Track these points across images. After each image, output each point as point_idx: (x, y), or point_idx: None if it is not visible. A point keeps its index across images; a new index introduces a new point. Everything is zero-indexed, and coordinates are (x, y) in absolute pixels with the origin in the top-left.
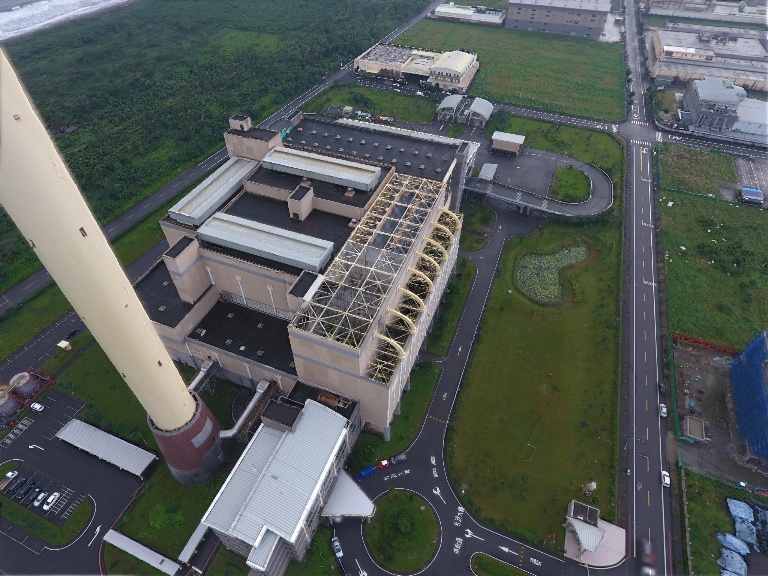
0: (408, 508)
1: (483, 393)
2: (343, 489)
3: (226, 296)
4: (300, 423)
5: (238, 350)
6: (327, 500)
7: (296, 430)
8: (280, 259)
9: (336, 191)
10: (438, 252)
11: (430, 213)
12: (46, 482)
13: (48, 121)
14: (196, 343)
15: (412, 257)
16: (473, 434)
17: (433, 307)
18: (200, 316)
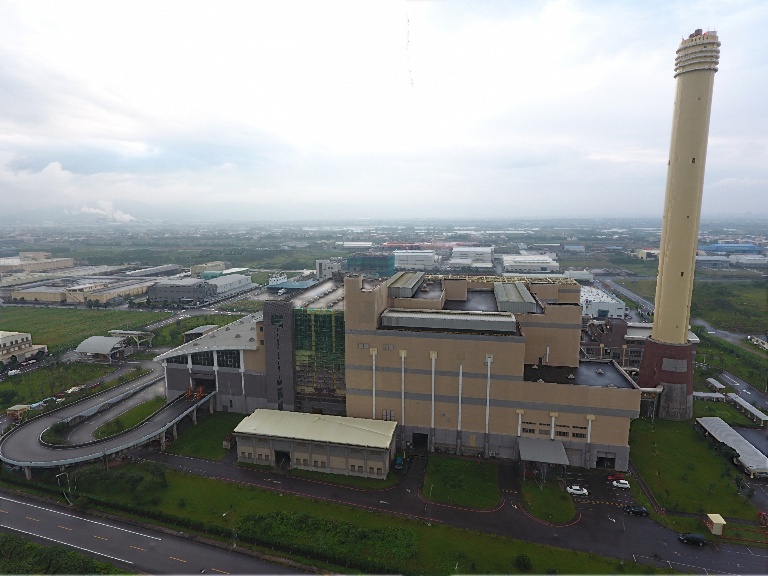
0: None
1: None
2: None
3: None
4: None
5: None
6: None
7: None
8: None
9: (427, 286)
10: None
11: None
12: None
13: None
14: None
15: None
16: None
17: None
18: None
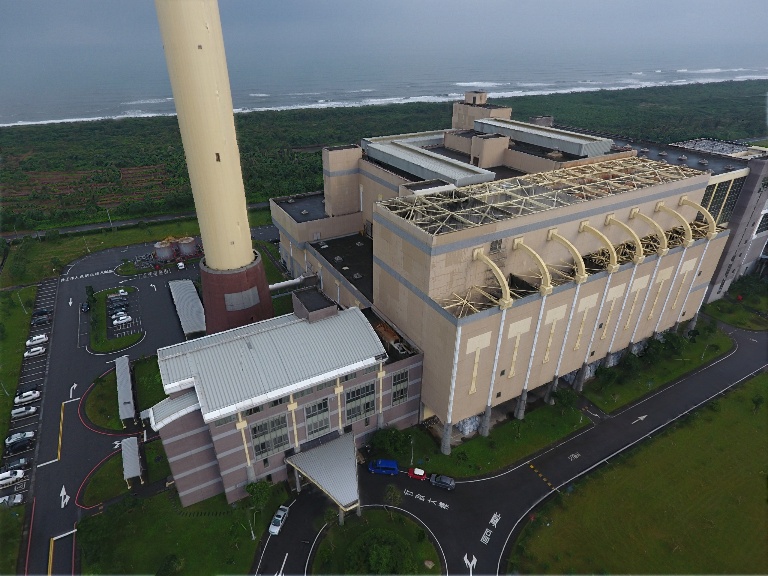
0: (406, 546)
1: (651, 489)
2: (335, 451)
3: (368, 229)
4: (326, 320)
5: (340, 268)
6: (307, 449)
7: (315, 323)
8: (424, 174)
9: (539, 153)
10: (655, 247)
11: (660, 185)
12: (134, 309)
13: (355, 142)
14: (311, 251)
15: (600, 219)
16: (593, 530)
17: (616, 328)
18: (332, 234)
